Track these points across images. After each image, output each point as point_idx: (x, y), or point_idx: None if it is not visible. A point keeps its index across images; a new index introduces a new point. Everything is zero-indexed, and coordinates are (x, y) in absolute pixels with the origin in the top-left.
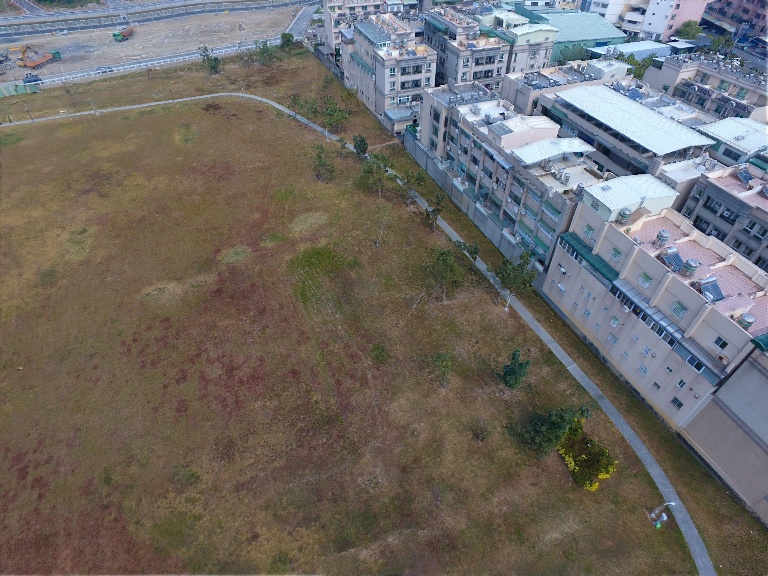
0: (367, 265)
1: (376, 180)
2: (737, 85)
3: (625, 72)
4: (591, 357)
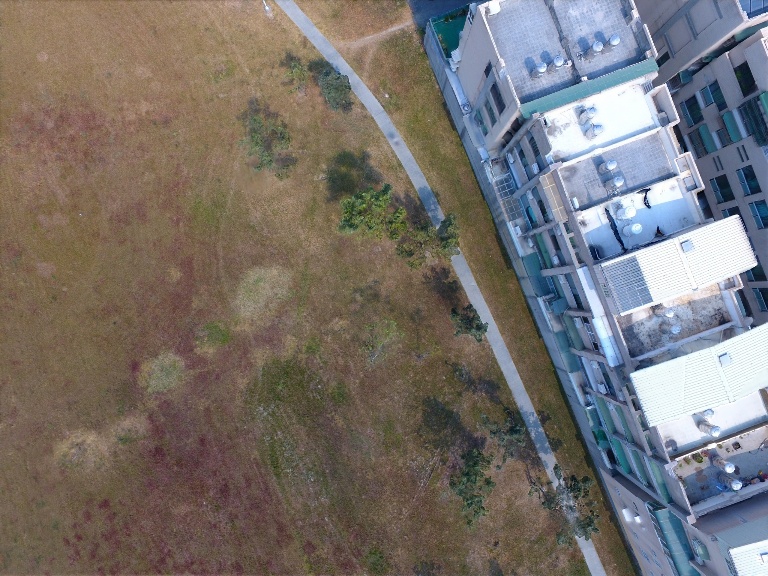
0: (358, 401)
1: None
2: None
3: None
4: (629, 570)
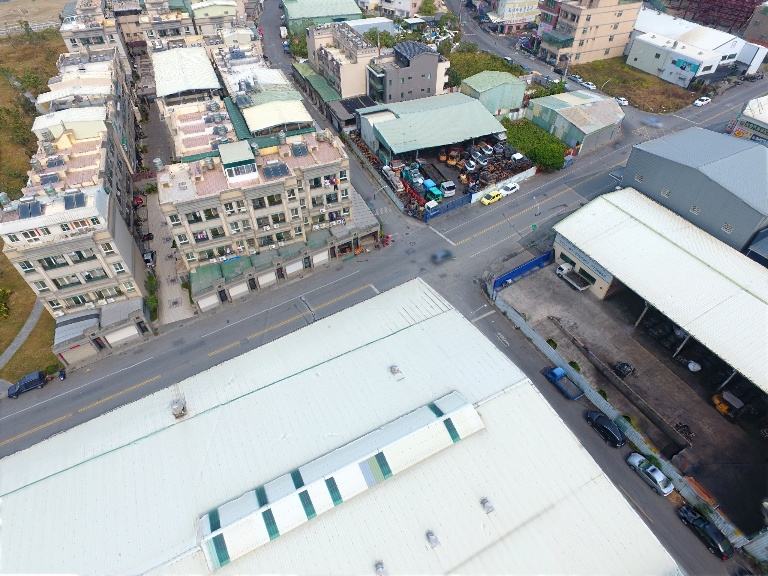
0: None
1: (7, 131)
2: (346, 48)
3: (249, 38)
4: None
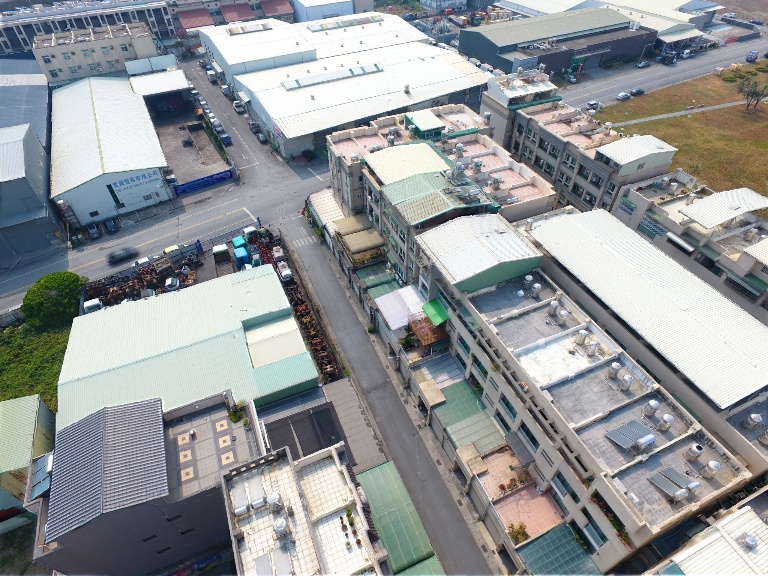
0: None
1: None
2: None
3: None
4: None
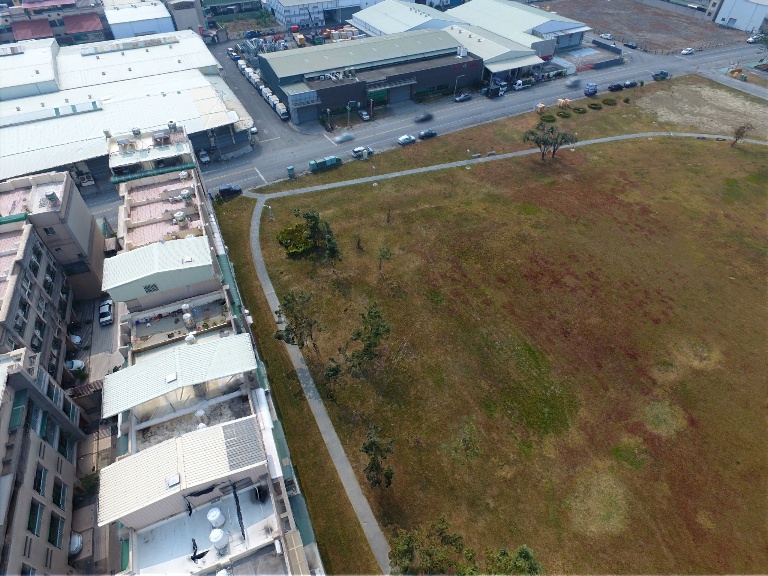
0: (471, 401)
1: None
2: None
3: None
4: (249, 299)
